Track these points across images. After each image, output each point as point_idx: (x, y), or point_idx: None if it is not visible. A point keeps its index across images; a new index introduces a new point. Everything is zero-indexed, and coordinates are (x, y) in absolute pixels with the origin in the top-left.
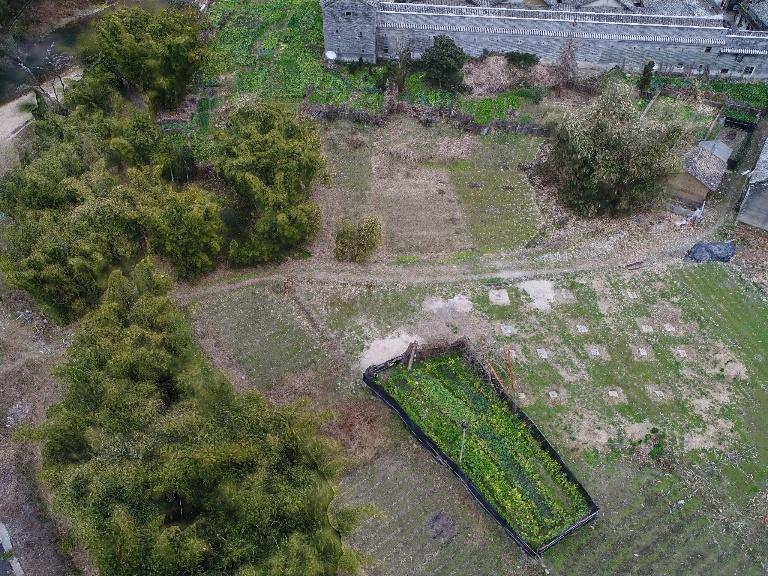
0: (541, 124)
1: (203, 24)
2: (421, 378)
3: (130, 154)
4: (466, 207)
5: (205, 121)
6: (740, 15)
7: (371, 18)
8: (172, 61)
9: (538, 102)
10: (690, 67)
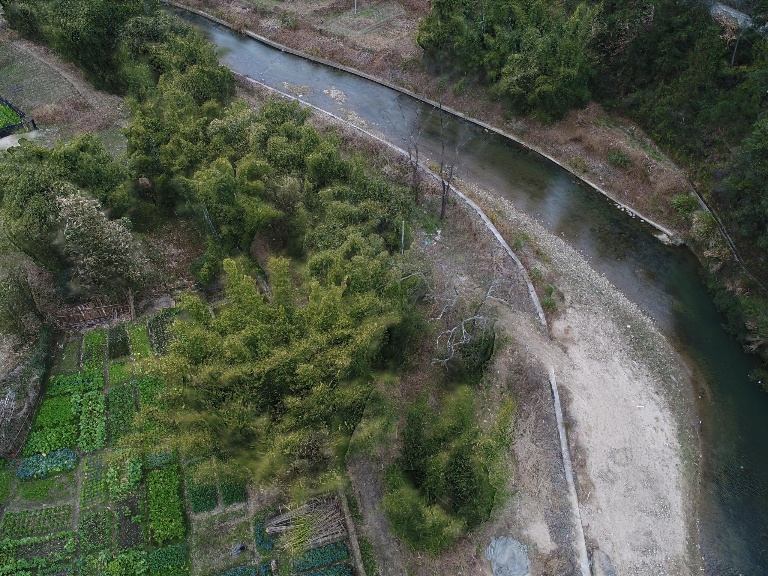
0: None
1: None
2: None
3: None
4: None
5: None
6: None
7: None
8: None
9: None
10: None
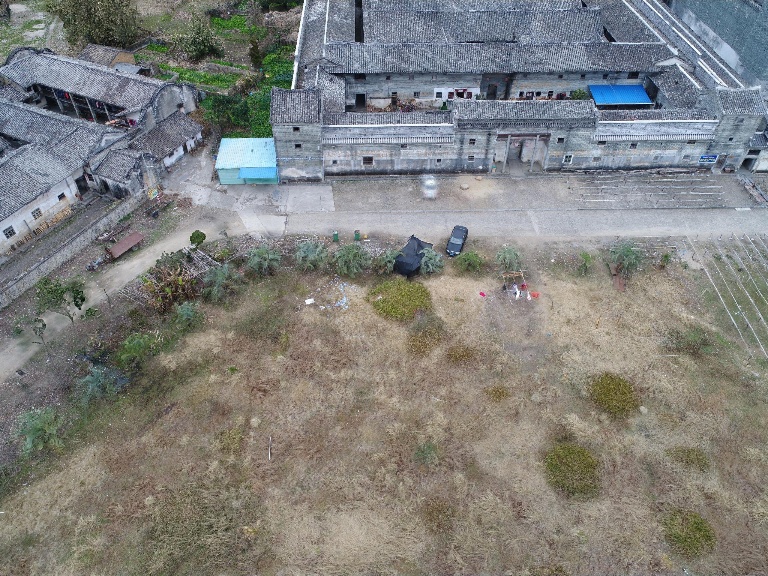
0: None
1: None
2: None
3: None
4: None
5: None
6: None
7: None
8: None
9: None
10: None
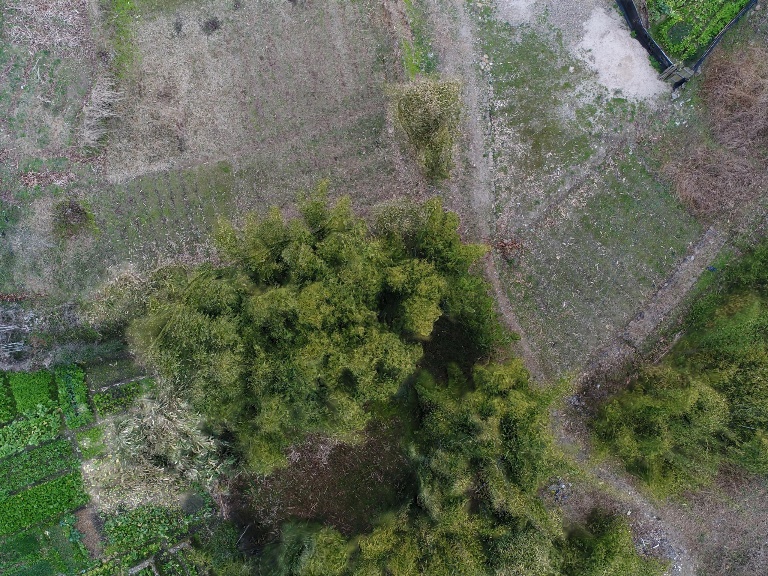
0: None
1: None
2: None
3: None
4: None
5: (33, 574)
6: None
7: None
8: None
9: None
10: None
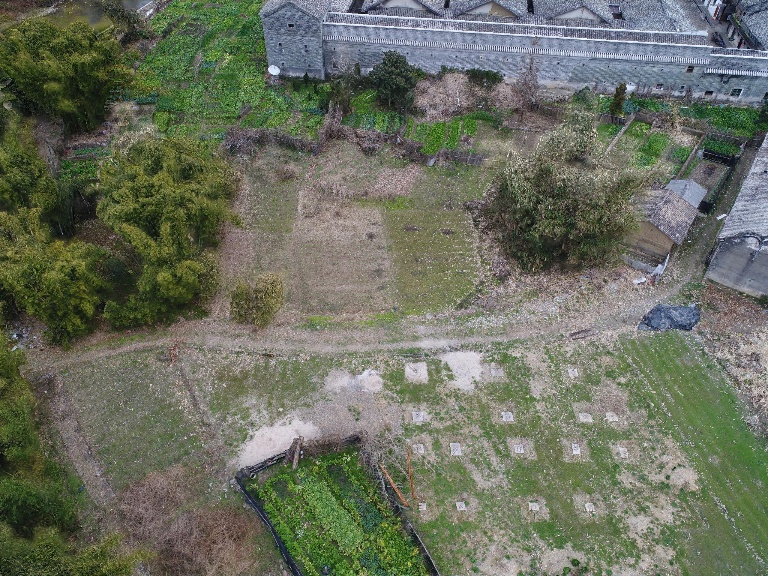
0: (494, 155)
1: (144, 32)
2: (306, 481)
3: (6, 194)
4: (396, 255)
5: None
6: (733, 27)
7: (316, 30)
8: (79, 81)
9: (497, 127)
10: (670, 88)
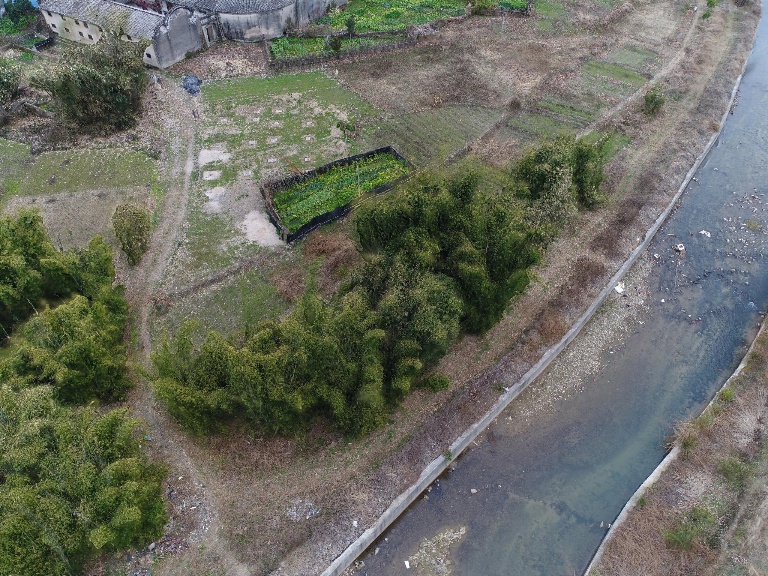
0: None
1: None
2: None
3: None
4: (84, 187)
5: None
6: None
7: None
8: None
9: None
10: None
